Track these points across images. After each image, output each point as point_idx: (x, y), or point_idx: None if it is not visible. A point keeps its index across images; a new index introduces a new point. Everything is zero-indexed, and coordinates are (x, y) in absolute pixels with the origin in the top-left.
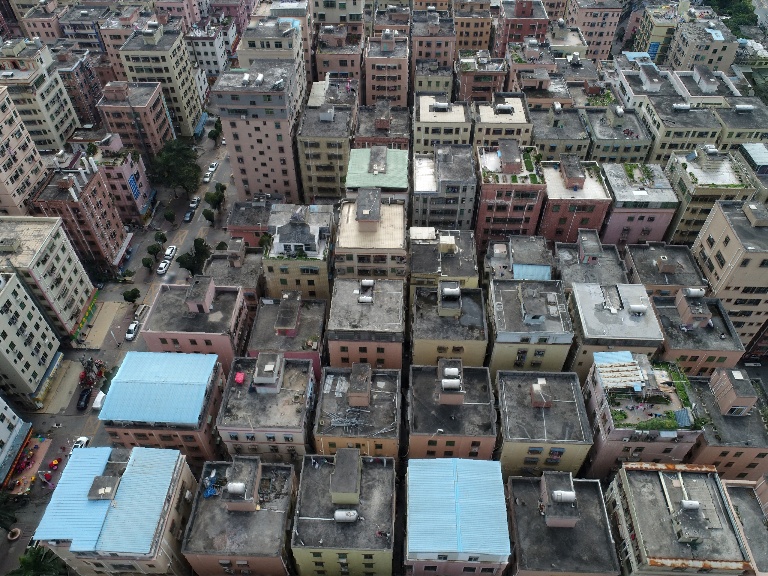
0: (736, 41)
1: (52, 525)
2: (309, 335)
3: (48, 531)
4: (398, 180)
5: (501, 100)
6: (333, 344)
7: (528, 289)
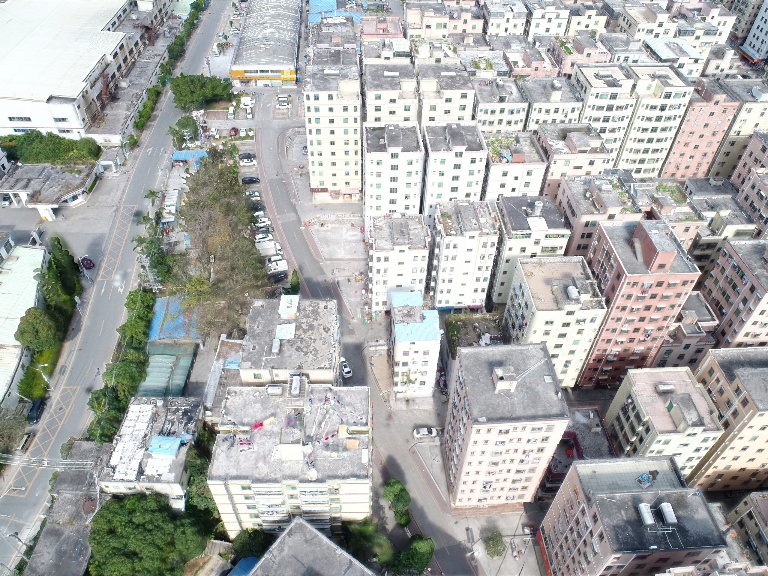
0: (256, 305)
1: None
2: None
3: None
4: (653, 41)
5: (611, 86)
6: None
7: (551, 4)
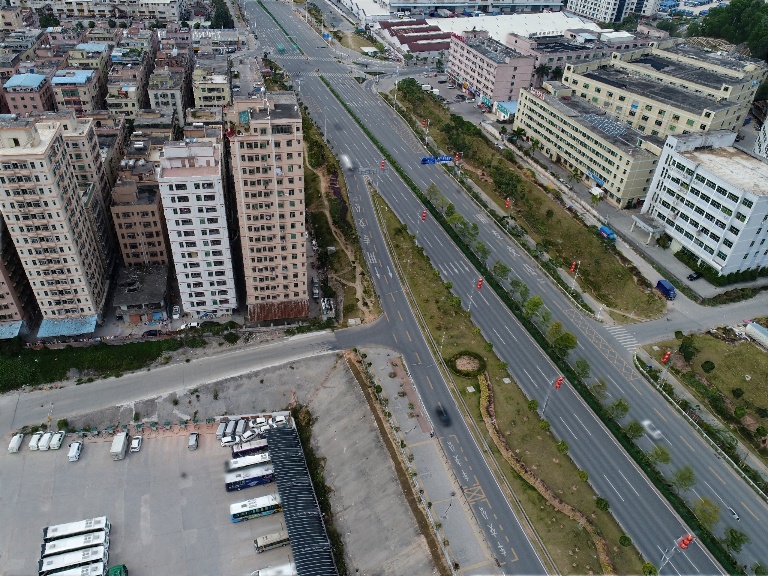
0: None
1: (81, 80)
2: (2, 81)
3: (83, 80)
4: None
5: None
6: (14, 70)
7: None
